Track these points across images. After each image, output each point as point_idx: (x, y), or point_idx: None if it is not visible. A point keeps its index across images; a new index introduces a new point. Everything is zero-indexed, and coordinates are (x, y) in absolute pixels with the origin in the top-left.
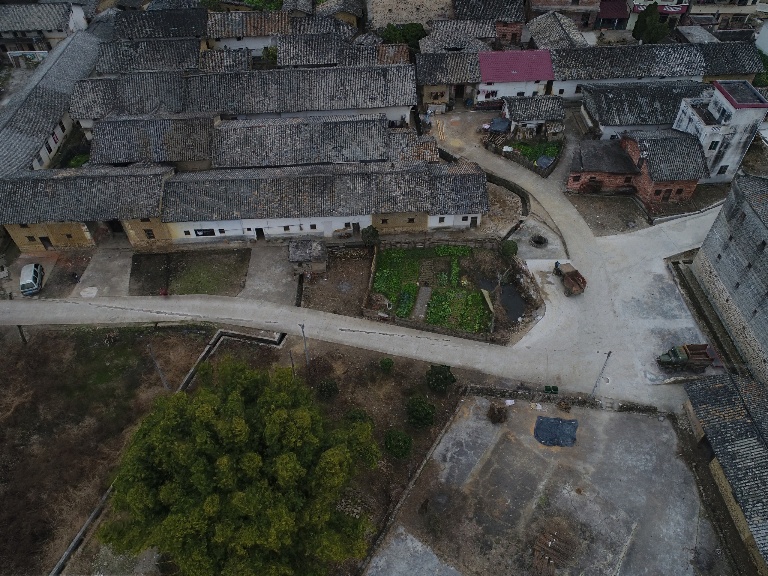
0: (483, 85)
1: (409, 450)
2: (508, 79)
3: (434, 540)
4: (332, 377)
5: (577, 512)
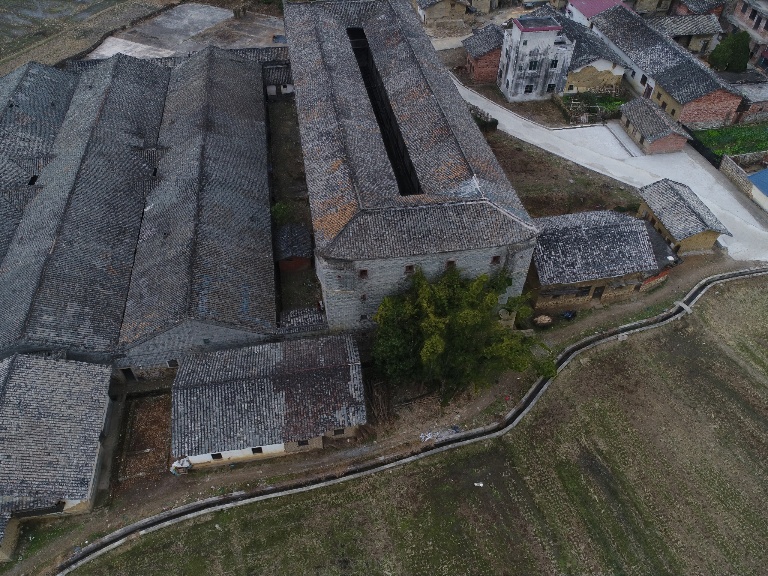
0: (570, 4)
1: (265, 1)
2: (575, 4)
3: None
4: None
5: None
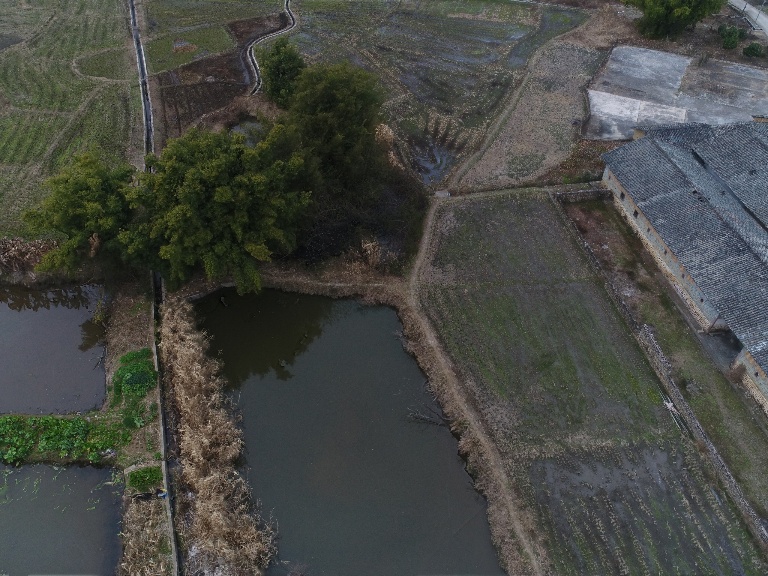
0: None
1: (730, 46)
2: None
3: (694, 65)
4: (749, 36)
5: (741, 95)
